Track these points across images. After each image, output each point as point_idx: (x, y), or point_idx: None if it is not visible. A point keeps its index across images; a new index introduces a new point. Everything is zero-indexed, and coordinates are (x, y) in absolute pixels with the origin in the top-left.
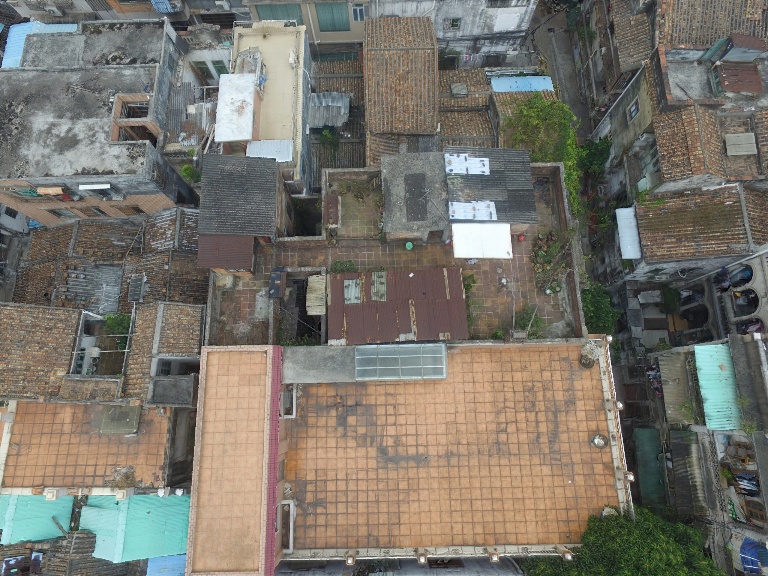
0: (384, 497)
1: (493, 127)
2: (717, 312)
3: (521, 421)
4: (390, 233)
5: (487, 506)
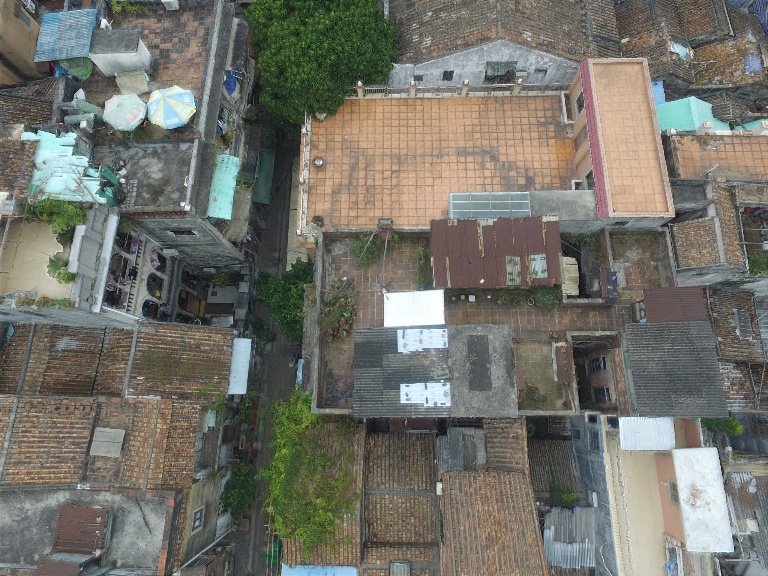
0: (492, 128)
1: (364, 509)
2: (174, 292)
3: (379, 179)
4: None
5: (412, 122)
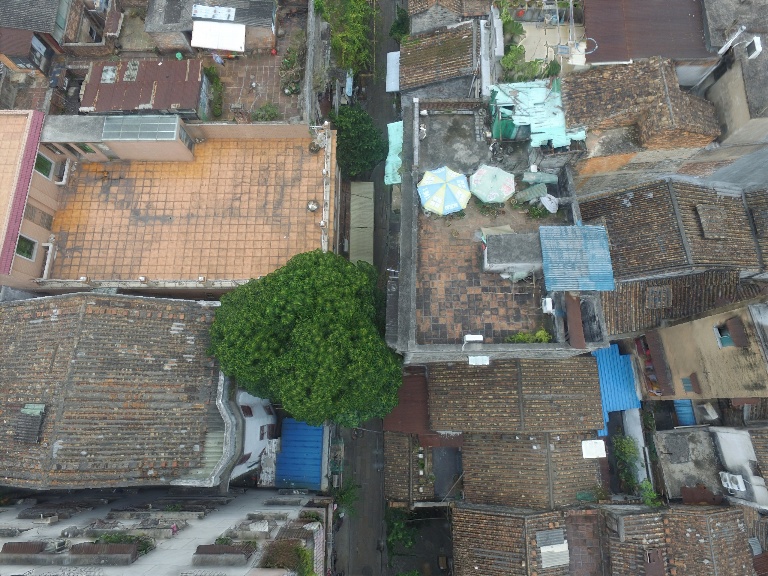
0: (131, 246)
1: None
2: None
3: (253, 192)
4: (155, 38)
5: (214, 253)
